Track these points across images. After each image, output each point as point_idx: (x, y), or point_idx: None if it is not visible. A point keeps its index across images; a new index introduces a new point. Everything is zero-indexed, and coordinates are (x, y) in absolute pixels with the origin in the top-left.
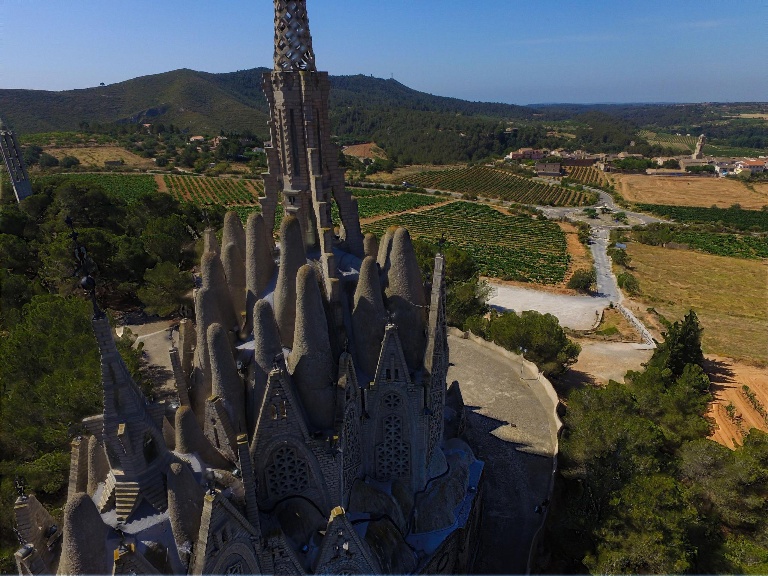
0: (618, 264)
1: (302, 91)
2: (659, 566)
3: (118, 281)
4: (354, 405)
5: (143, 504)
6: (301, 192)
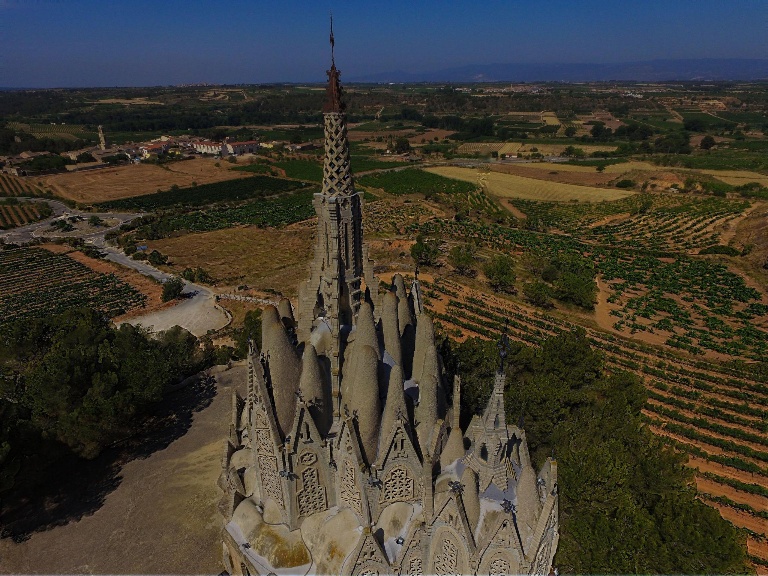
0: (159, 264)
1: (360, 207)
2: (491, 372)
3: None
4: None
5: None
6: None
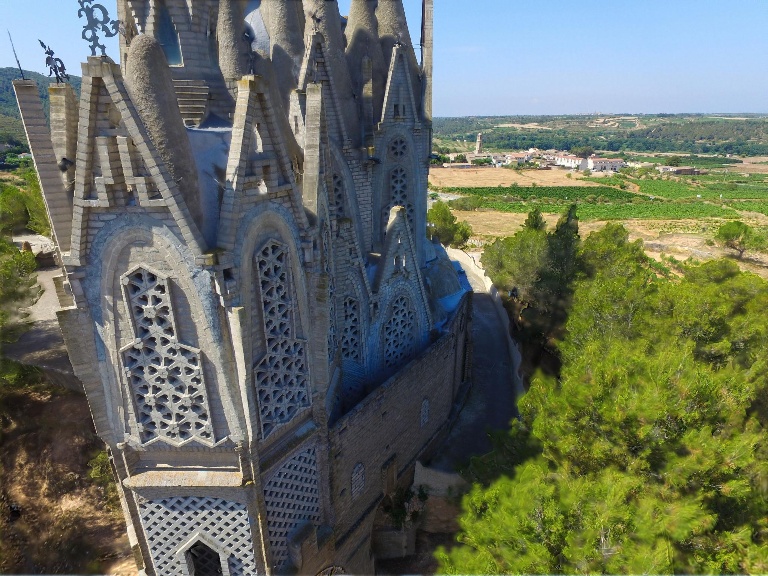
0: None
1: None
2: (631, 281)
3: None
4: None
5: (213, 116)
6: None
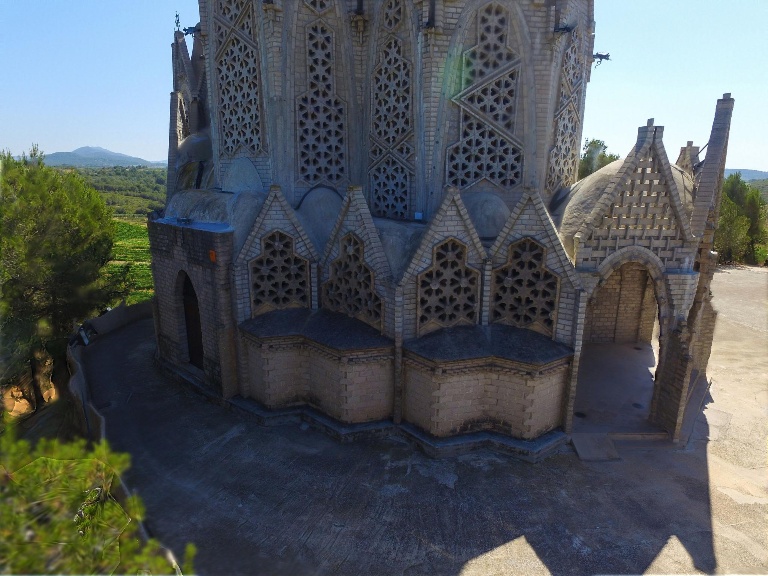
0: None
1: None
2: None
3: None
4: None
5: None
6: None
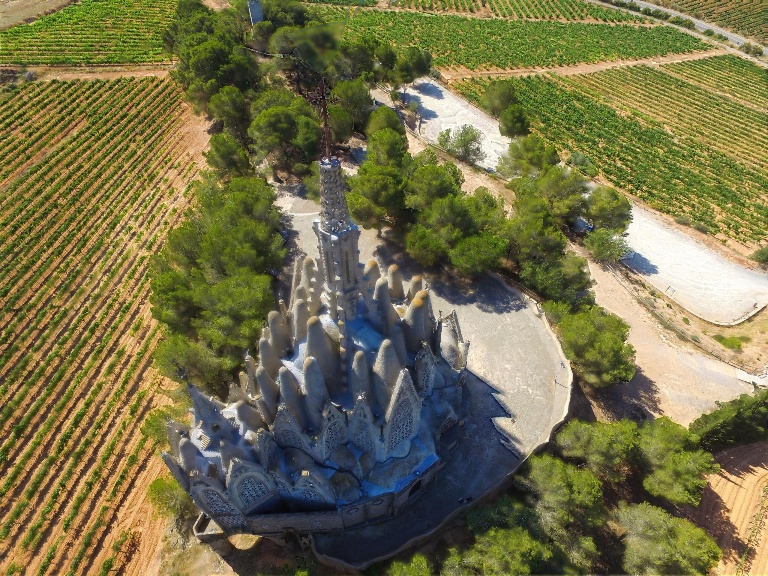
0: None
1: None
2: None
3: (295, 160)
4: (338, 419)
5: (212, 445)
6: (333, 292)
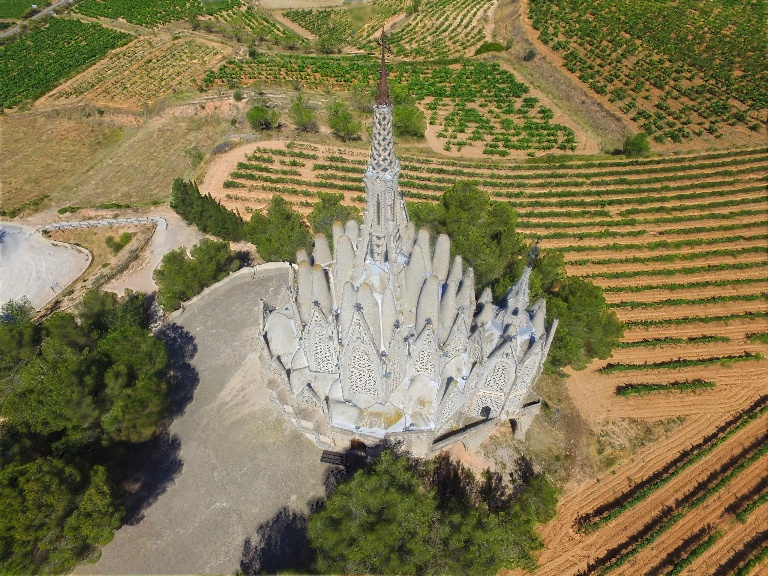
0: None
1: None
2: None
3: None
4: None
5: None
6: None
